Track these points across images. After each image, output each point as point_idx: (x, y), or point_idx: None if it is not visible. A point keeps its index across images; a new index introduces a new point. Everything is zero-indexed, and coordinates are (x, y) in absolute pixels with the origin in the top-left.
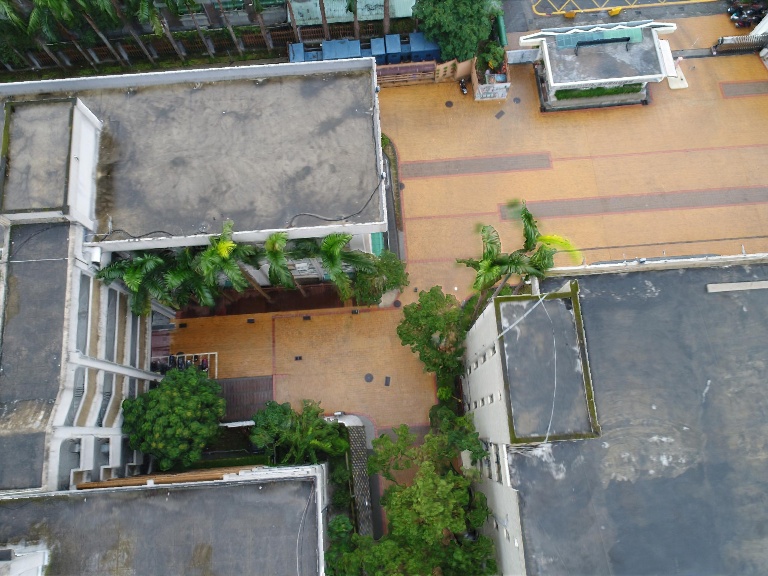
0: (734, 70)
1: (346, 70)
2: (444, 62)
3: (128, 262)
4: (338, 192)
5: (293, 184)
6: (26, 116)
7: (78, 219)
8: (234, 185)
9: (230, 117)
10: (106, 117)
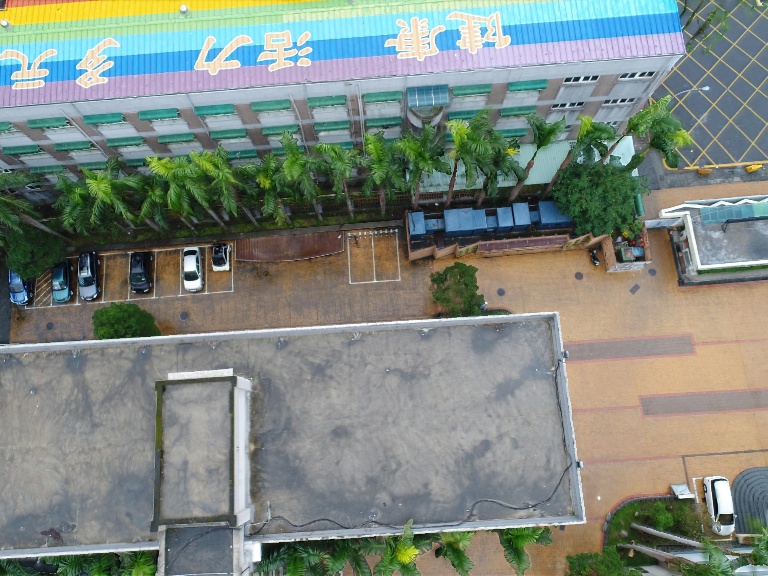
0: None
1: (523, 320)
2: (578, 236)
3: (286, 549)
4: (523, 473)
5: (471, 462)
6: (179, 397)
7: (242, 522)
8: (405, 462)
9: (395, 376)
10: (255, 373)
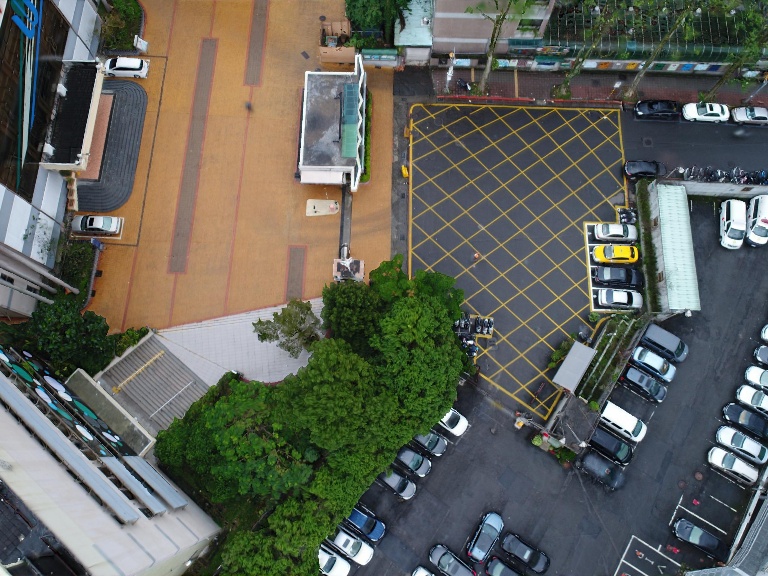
0: (320, 265)
1: None
2: None
3: None
4: None
5: None
6: None
7: None
8: None
9: None
10: None
